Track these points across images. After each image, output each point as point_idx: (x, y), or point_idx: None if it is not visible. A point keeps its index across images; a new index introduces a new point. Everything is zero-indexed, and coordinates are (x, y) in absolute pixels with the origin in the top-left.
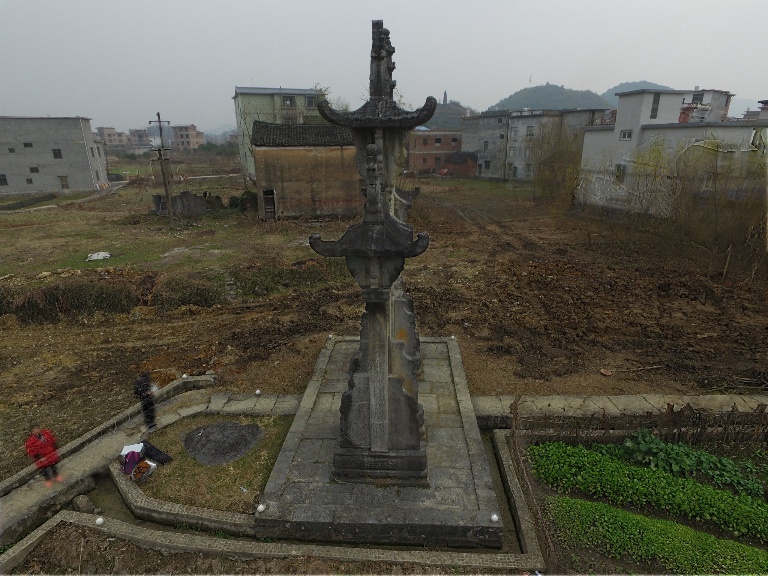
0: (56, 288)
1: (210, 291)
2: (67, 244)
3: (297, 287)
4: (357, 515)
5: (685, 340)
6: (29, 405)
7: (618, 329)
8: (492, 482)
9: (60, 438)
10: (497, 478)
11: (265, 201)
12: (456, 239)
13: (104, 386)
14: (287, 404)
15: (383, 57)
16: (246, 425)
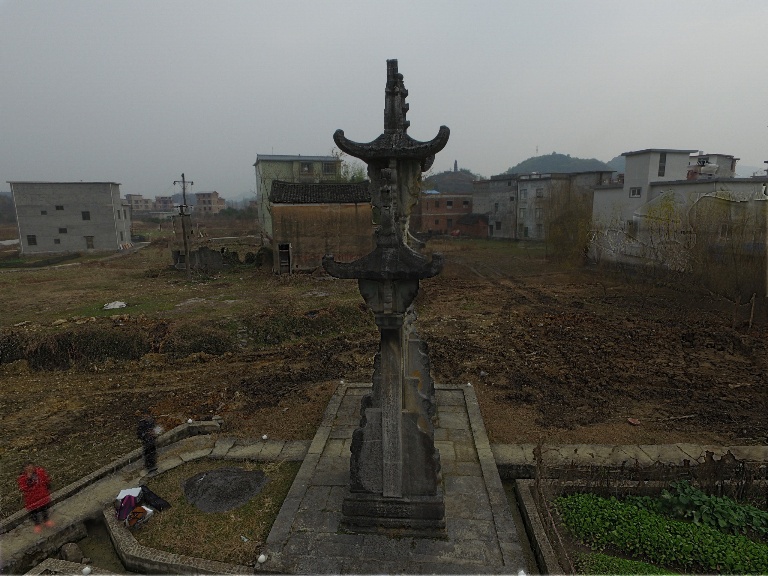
0: (70, 334)
1: (222, 339)
2: (86, 295)
3: (309, 336)
4: (368, 568)
5: (716, 390)
6: (29, 449)
7: (643, 378)
8: (517, 535)
9: (56, 483)
10: (522, 532)
11: (280, 255)
12: (469, 293)
13: (107, 431)
14: (295, 450)
15: (397, 93)
16: (251, 471)
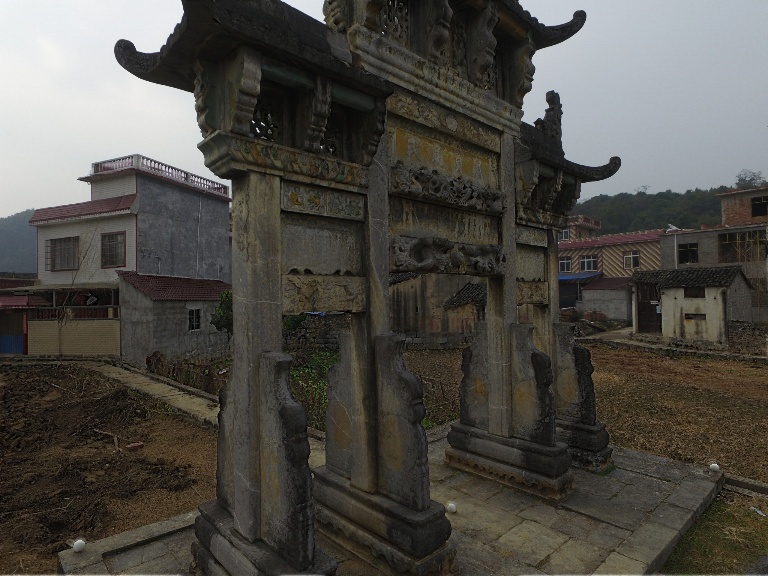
0: None
1: None
2: None
3: None
4: None
5: None
6: None
7: None
8: None
9: None
10: None
11: None
12: None
13: None
14: None
15: None
16: None
